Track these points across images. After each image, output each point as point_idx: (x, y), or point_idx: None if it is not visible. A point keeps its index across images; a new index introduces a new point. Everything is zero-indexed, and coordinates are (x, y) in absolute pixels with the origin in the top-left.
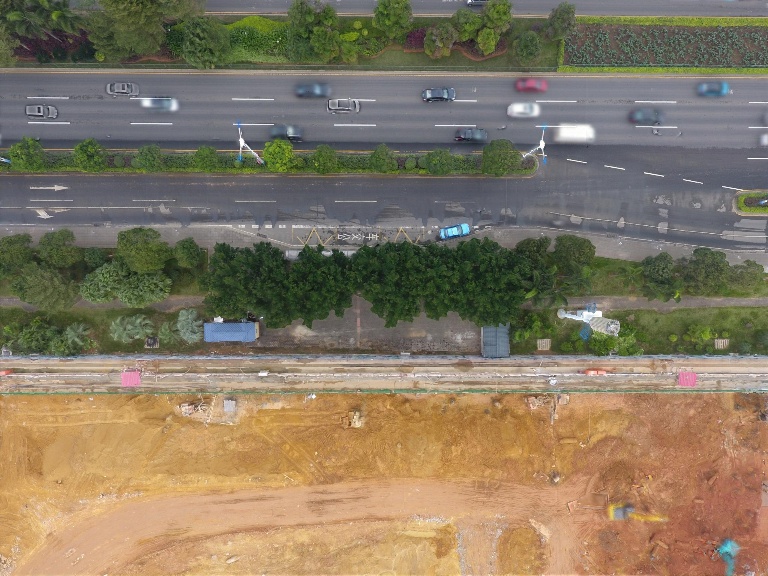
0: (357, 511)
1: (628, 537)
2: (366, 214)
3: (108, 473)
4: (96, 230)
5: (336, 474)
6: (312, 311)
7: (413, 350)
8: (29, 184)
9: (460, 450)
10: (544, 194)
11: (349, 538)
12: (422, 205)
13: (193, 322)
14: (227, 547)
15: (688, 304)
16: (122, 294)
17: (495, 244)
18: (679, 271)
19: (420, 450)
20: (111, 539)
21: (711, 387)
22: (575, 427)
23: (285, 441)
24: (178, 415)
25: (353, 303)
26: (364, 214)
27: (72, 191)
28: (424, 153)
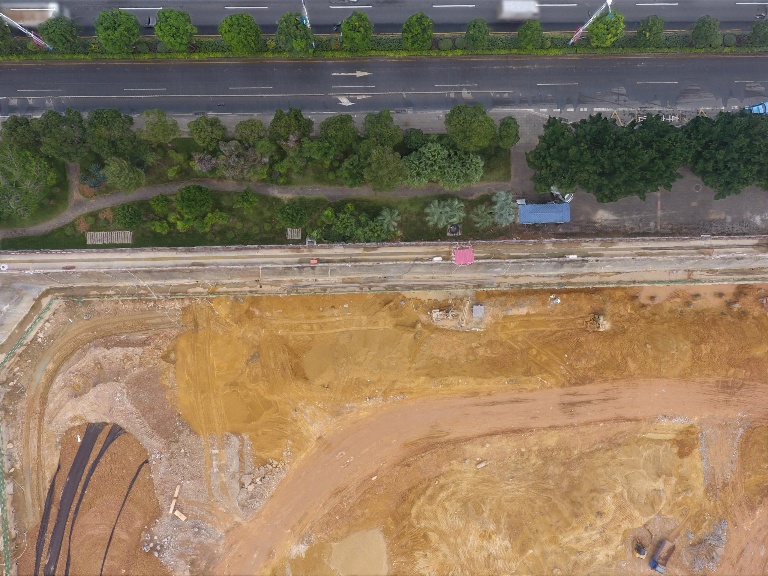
0: (607, 412)
1: None
2: (667, 95)
3: (375, 376)
4: (399, 116)
5: (587, 376)
6: (649, 182)
7: (712, 232)
8: (331, 70)
9: (709, 349)
10: None
11: (593, 441)
12: (723, 85)
13: (510, 203)
14: (482, 450)
15: None
16: (452, 172)
17: None
18: None
19: (673, 349)
20: (379, 441)
21: None
22: None
23: (531, 346)
24: (424, 323)
25: None
26: (665, 95)
27: (374, 77)
28: (726, 31)
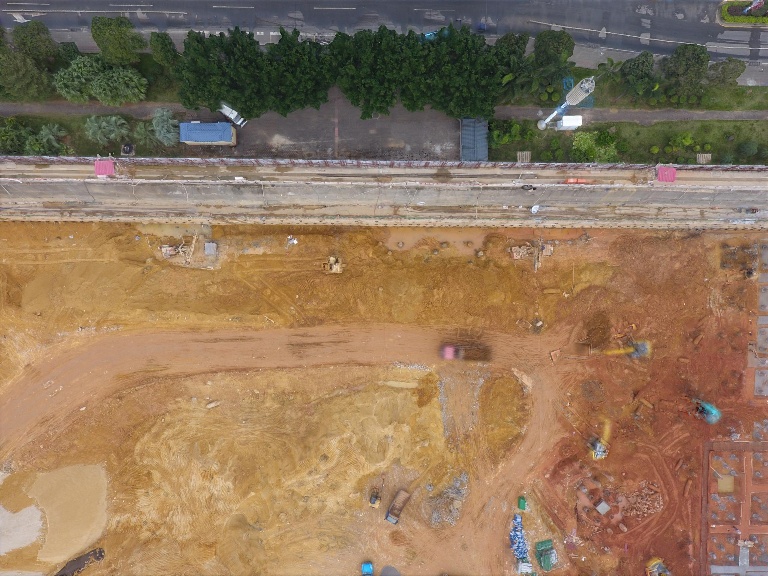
0: (338, 355)
1: (611, 387)
2: (345, 21)
3: (87, 305)
4: (73, 35)
5: (317, 317)
6: (287, 97)
7: None
8: None
9: (442, 294)
10: (525, 3)
11: (330, 386)
12: (401, 13)
13: (169, 120)
14: (207, 388)
15: (670, 117)
16: (96, 83)
17: (473, 35)
18: None
19: (401, 291)
20: (90, 372)
21: (694, 217)
22: (559, 278)
23: (266, 286)
24: (159, 259)
25: (331, 112)
26: (343, 21)
27: None
28: None
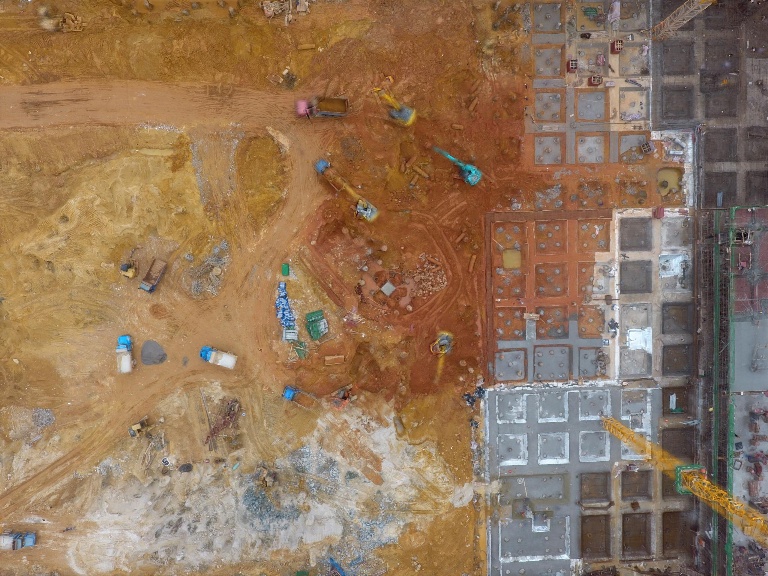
0: (77, 114)
1: (371, 144)
2: None
3: None
4: None
5: (51, 72)
6: None
7: None
8: None
9: (182, 44)
10: None
11: (77, 154)
12: None
13: None
14: None
15: None
16: None
17: None
18: None
19: (136, 40)
20: None
21: None
22: (315, 35)
23: (0, 47)
24: None
25: None
26: None
27: None
28: None
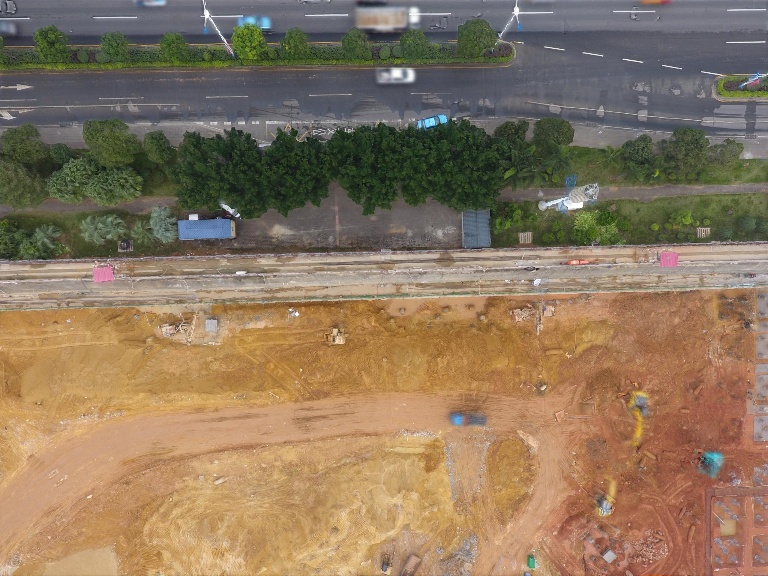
0: (344, 427)
1: (615, 445)
2: (341, 108)
3: (88, 393)
4: (62, 130)
5: (322, 390)
6: (287, 198)
7: (393, 247)
8: None
9: (446, 362)
10: (522, 83)
11: (337, 456)
12: (398, 97)
13: (166, 219)
14: (214, 466)
15: (669, 193)
16: (90, 188)
17: (472, 126)
18: (659, 153)
19: (406, 362)
20: (94, 459)
21: (694, 284)
22: (561, 338)
23: (269, 360)
24: (159, 337)
25: (331, 200)
26: (339, 108)
27: (35, 90)
28: (399, 43)
